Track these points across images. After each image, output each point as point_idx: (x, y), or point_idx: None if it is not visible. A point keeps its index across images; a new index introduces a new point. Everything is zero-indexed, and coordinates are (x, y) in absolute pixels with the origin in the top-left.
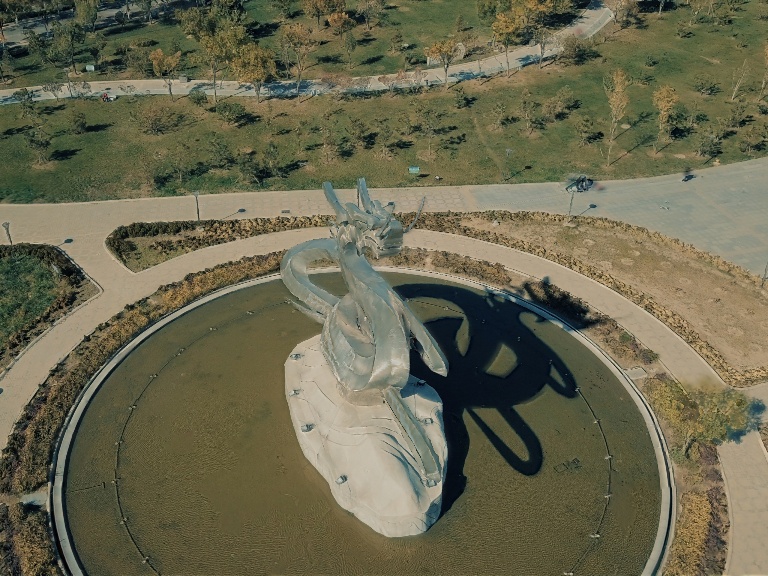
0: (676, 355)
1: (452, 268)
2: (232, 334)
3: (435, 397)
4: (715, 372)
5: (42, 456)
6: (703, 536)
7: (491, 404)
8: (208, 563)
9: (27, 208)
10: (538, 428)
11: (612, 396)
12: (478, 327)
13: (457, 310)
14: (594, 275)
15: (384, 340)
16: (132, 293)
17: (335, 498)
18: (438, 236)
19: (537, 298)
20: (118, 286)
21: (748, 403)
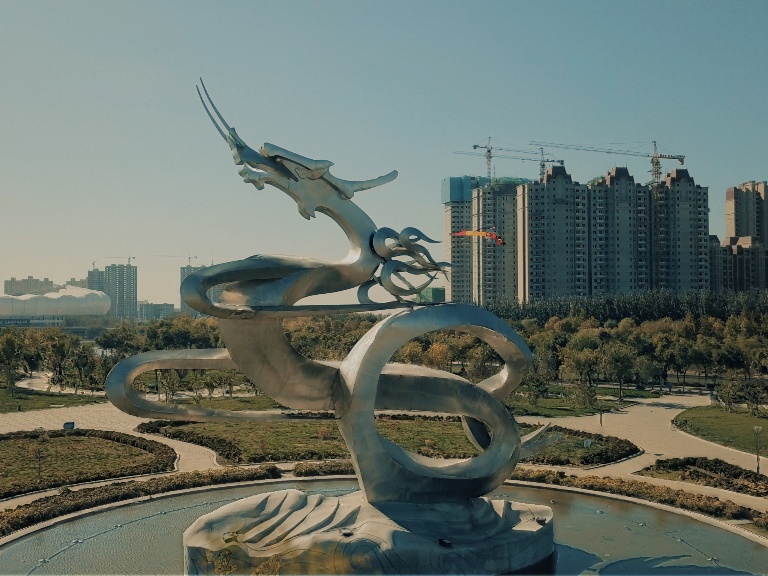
0: None
1: None
2: None
3: (407, 541)
4: None
5: None
6: None
7: None
8: None
9: (700, 442)
10: None
11: None
12: None
13: None
14: None
15: None
16: None
17: None
18: None
19: None
20: (599, 472)
21: None
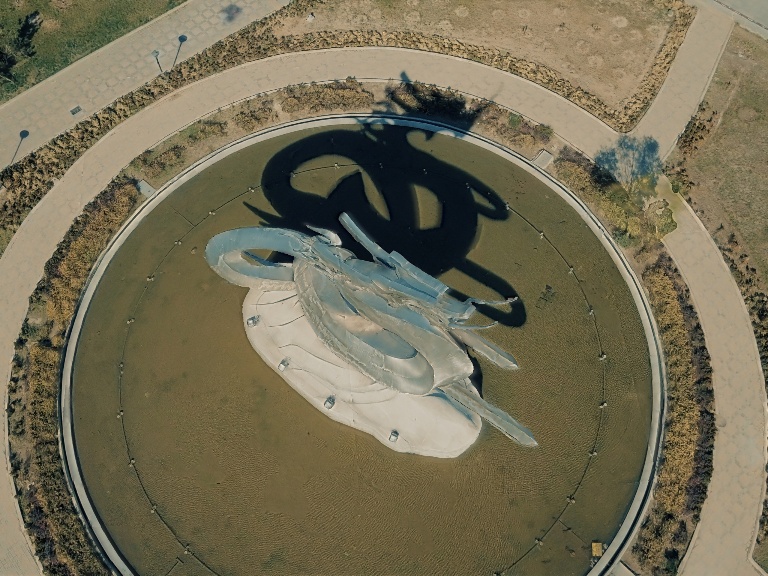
0: (564, 119)
1: (309, 109)
2: (154, 316)
3: None
4: (604, 123)
5: (101, 575)
6: (681, 316)
7: (447, 265)
8: (332, 574)
9: None
10: (500, 270)
11: (538, 198)
12: (380, 175)
13: (347, 163)
14: (445, 49)
15: (442, 363)
16: (3, 323)
17: (389, 447)
18: (264, 66)
19: (412, 110)
20: None
21: (644, 146)
